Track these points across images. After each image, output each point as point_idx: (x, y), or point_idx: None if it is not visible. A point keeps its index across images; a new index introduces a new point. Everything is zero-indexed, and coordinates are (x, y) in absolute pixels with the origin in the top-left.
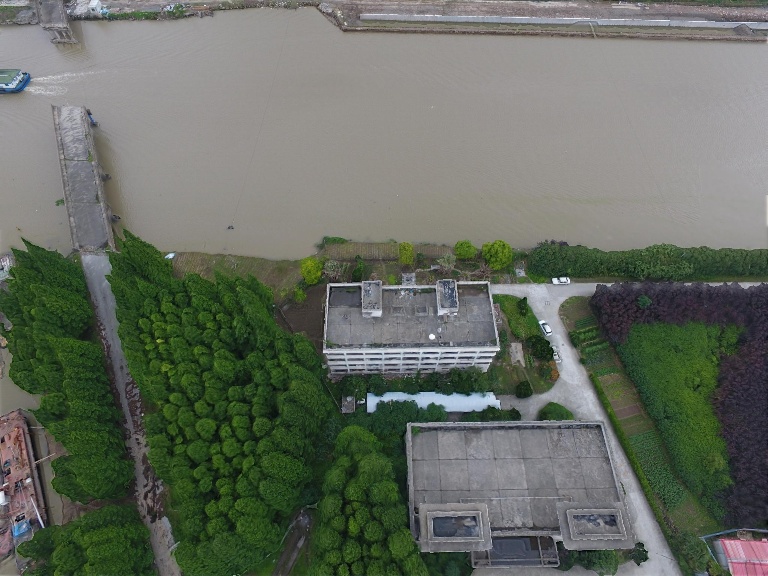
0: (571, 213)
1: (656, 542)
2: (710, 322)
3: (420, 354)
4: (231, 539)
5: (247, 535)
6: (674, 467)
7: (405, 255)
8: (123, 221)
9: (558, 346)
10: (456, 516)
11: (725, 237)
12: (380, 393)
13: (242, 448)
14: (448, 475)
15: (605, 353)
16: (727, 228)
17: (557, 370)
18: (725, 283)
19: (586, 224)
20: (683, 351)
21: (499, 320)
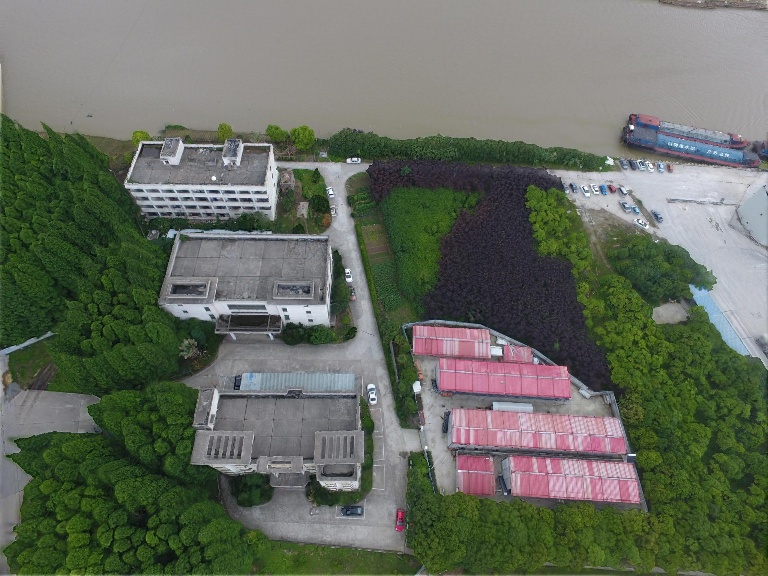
0: (381, 115)
1: (371, 331)
2: (458, 189)
3: (206, 193)
4: (10, 286)
5: (25, 286)
6: (398, 282)
7: (221, 132)
8: (1, 112)
9: (337, 205)
10: (190, 282)
11: (503, 138)
12: (179, 228)
13: (37, 237)
14: (201, 267)
15: (373, 211)
16: (505, 131)
17: (331, 221)
18: (478, 163)
19: (391, 124)
20: (429, 208)
21: (289, 182)
